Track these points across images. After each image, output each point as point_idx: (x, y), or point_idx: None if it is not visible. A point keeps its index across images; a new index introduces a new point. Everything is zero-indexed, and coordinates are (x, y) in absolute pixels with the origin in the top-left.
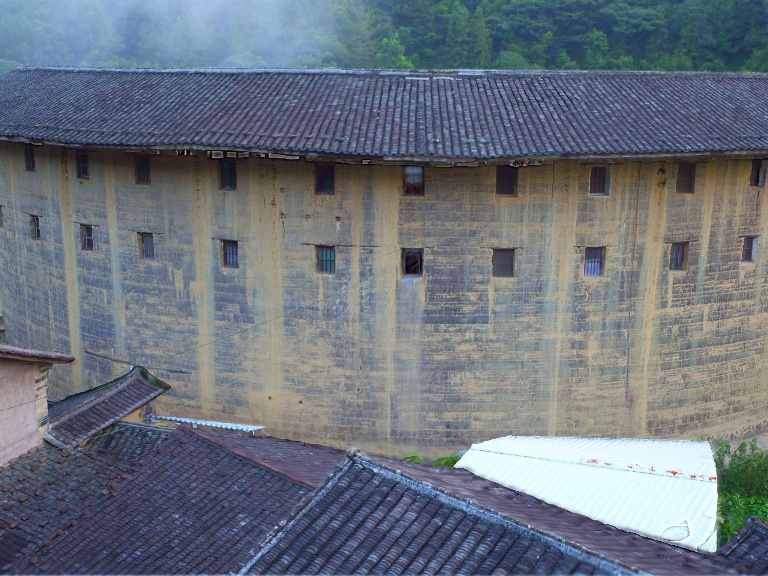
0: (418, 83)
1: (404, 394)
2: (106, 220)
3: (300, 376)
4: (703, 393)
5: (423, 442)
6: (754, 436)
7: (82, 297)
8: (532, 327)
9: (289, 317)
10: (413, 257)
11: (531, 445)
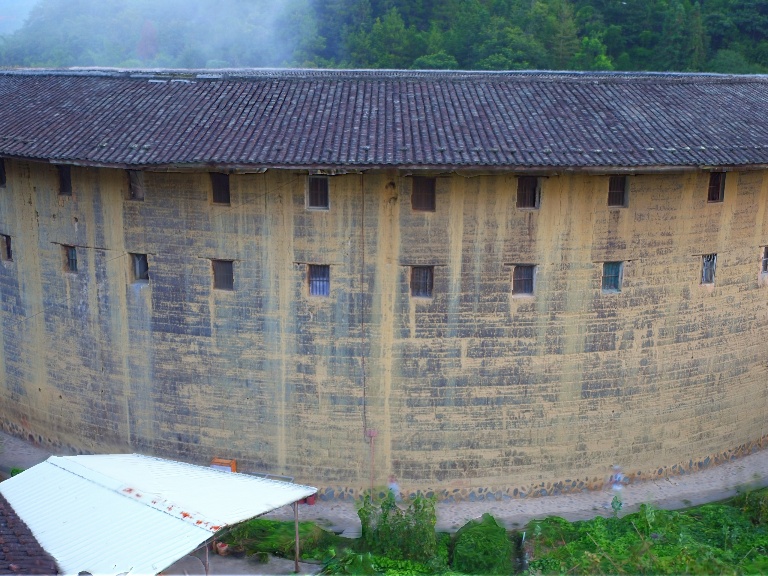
0: (153, 86)
1: (139, 400)
2: None
3: (59, 371)
4: (467, 438)
5: (159, 451)
6: (551, 495)
7: None
8: (255, 345)
9: (48, 313)
10: (146, 262)
11: (117, 465)
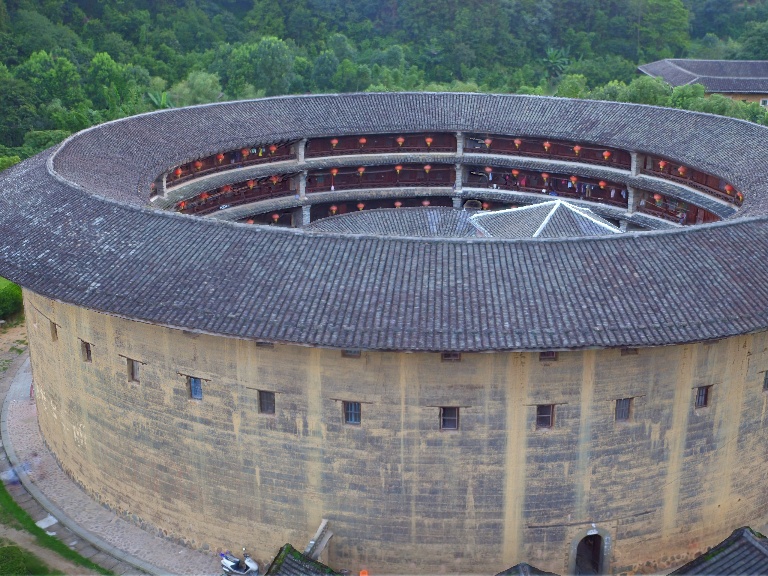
0: None
1: None
2: (579, 396)
3: (742, 479)
4: None
5: None
6: None
7: (531, 476)
8: None
9: (741, 435)
10: None
11: None
